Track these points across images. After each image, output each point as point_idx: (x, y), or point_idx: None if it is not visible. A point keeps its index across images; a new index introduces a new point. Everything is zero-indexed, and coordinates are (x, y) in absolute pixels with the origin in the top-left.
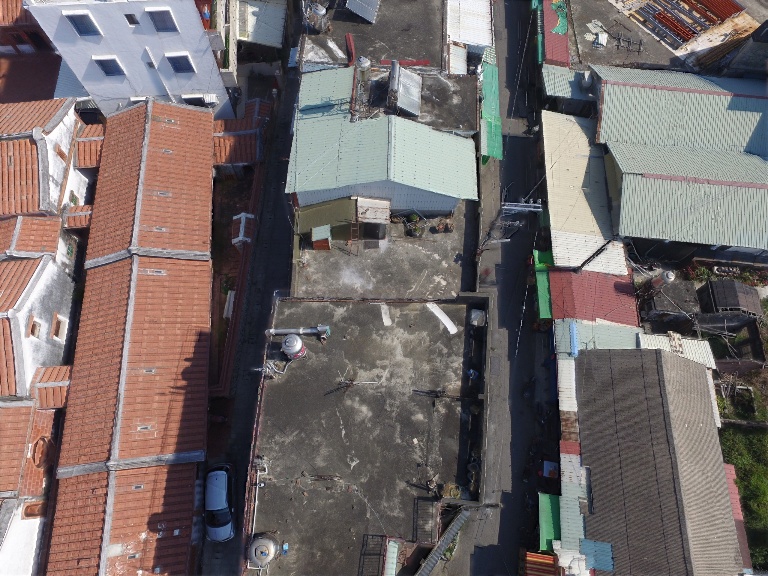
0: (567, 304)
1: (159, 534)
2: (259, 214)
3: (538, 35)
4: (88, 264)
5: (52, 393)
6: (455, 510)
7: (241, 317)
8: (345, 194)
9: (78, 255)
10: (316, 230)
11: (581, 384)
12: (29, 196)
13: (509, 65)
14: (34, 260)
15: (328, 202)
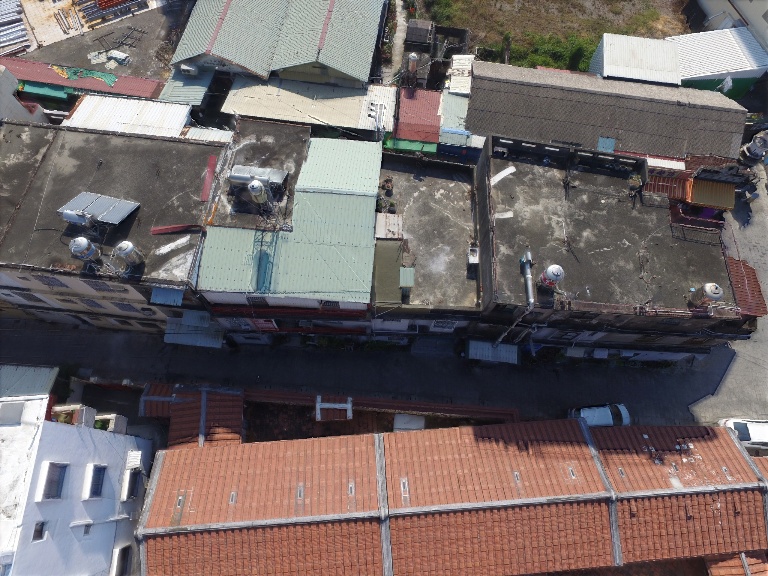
0: (427, 130)
1: (652, 449)
2: None
3: None
4: None
5: None
6: None
7: None
8: None
9: None
10: (403, 282)
11: None
12: None
13: None
14: None
15: None
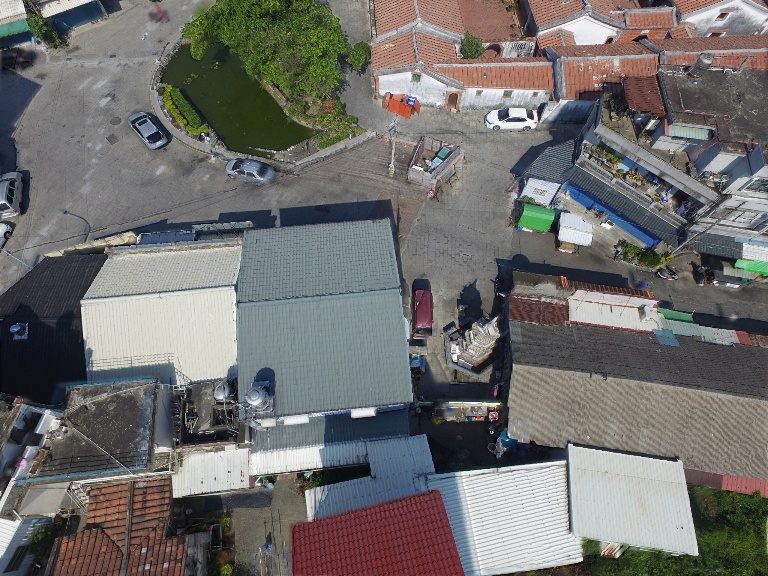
0: None
1: None
2: None
3: None
4: None
5: (682, 34)
6: None
7: None
8: None
9: None
10: None
11: None
12: None
13: None
14: (767, 7)
15: None
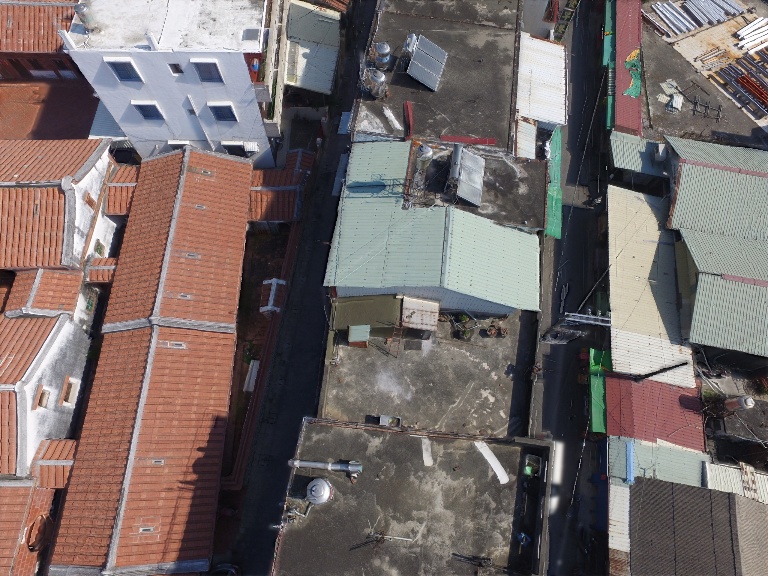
0: (625, 419)
1: None
2: (291, 277)
3: (608, 96)
4: (106, 328)
5: (54, 472)
6: None
7: (262, 396)
8: (390, 292)
9: (98, 308)
10: (354, 329)
11: (636, 519)
12: (52, 249)
13: (572, 124)
14: (50, 319)
15: (370, 297)
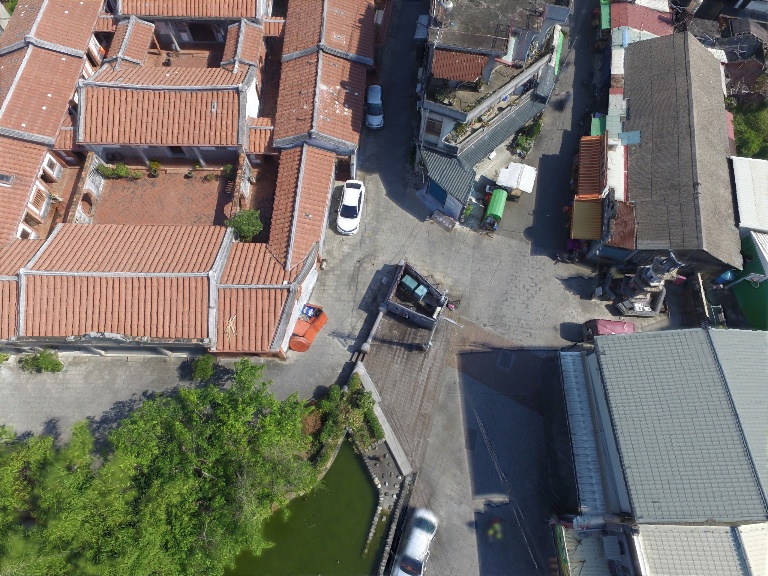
0: (622, 19)
1: (347, 90)
2: None
3: None
4: None
5: (273, 27)
6: (546, 52)
7: None
8: None
9: None
10: None
11: (628, 60)
12: None
13: None
14: None
15: None
